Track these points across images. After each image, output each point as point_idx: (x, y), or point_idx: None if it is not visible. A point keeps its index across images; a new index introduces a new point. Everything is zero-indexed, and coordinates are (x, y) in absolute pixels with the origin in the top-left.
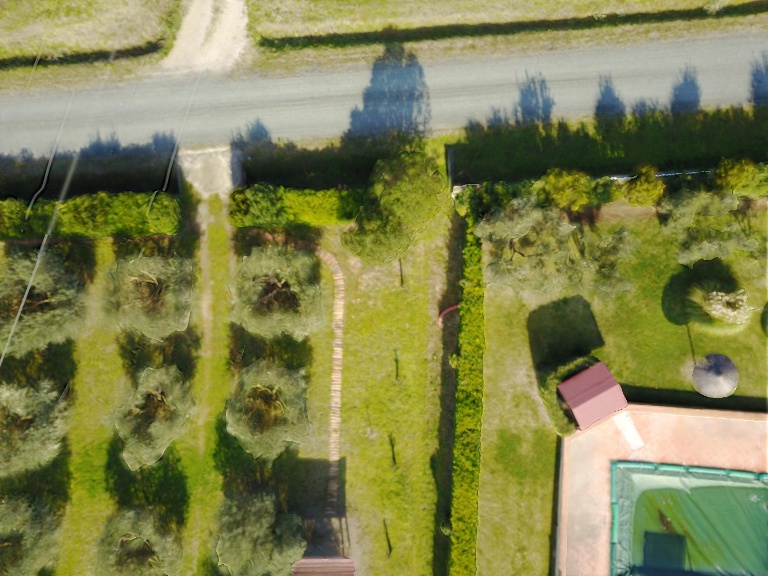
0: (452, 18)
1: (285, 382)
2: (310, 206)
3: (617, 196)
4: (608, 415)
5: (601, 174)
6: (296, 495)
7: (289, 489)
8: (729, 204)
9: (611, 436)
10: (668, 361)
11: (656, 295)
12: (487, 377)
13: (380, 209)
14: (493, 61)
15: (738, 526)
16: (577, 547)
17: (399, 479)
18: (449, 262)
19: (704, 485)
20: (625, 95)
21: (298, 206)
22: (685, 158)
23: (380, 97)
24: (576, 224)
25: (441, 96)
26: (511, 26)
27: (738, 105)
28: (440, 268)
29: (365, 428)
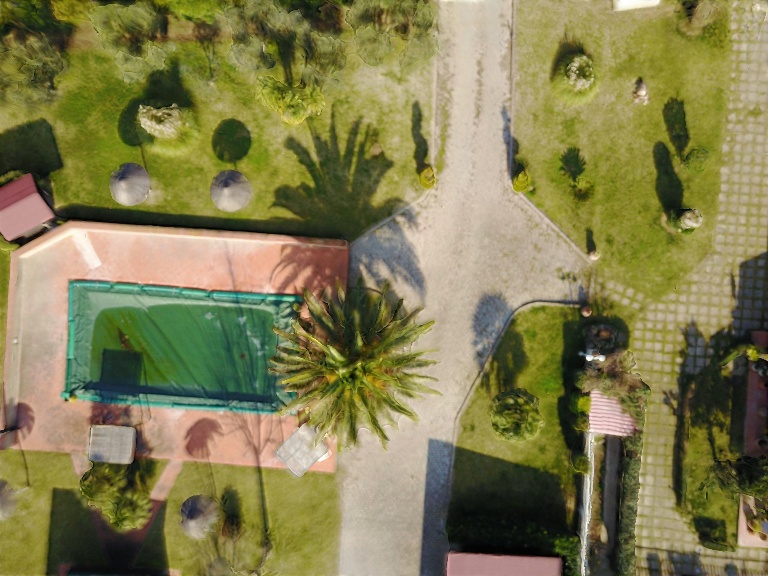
0: None
1: None
2: None
3: None
4: (54, 232)
5: None
6: None
7: None
8: (135, 12)
9: (70, 256)
10: None
11: (114, 117)
12: None
13: None
14: None
15: (193, 342)
16: (34, 363)
17: None
18: None
19: (159, 303)
20: None
21: None
22: None
23: None
24: None
25: None
26: None
27: None
28: None
29: None
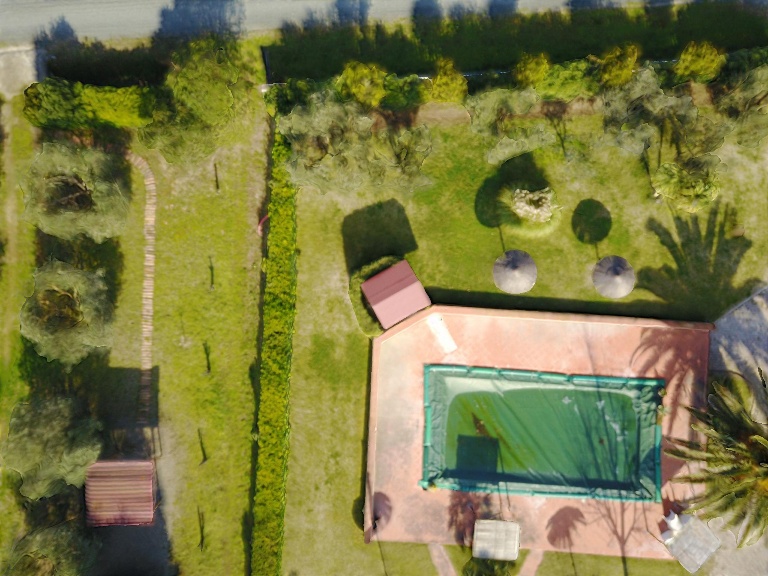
0: None
1: (76, 281)
2: (111, 104)
3: (427, 96)
4: (418, 317)
5: None
6: (106, 405)
7: (99, 399)
8: (527, 97)
9: (424, 340)
10: (480, 264)
11: (470, 198)
12: (302, 283)
13: (174, 102)
14: None
15: (550, 427)
16: (389, 451)
17: (214, 388)
18: (268, 168)
19: (516, 387)
20: None
21: (98, 103)
22: (503, 62)
23: None
24: (393, 128)
25: None
26: None
27: (556, 8)
28: (260, 175)
29: (179, 337)
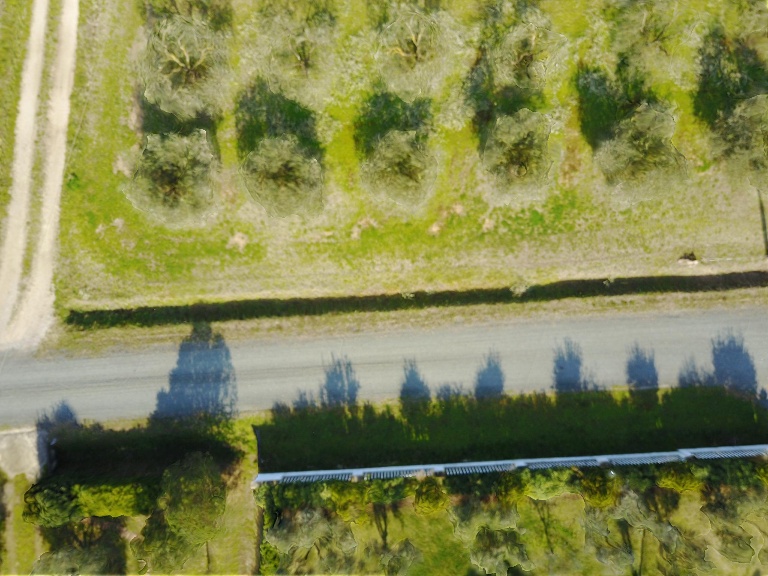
0: (262, 294)
1: None
2: (106, 503)
3: (411, 494)
4: None
5: (405, 457)
6: None
7: None
8: (507, 525)
9: None
10: None
11: None
12: None
13: (164, 524)
14: (299, 343)
15: None
16: None
17: None
18: (257, 539)
19: None
20: (430, 379)
21: (93, 504)
22: (488, 442)
23: (186, 378)
24: (379, 509)
25: (247, 378)
26: (322, 301)
27: (540, 390)
28: (250, 543)
29: None
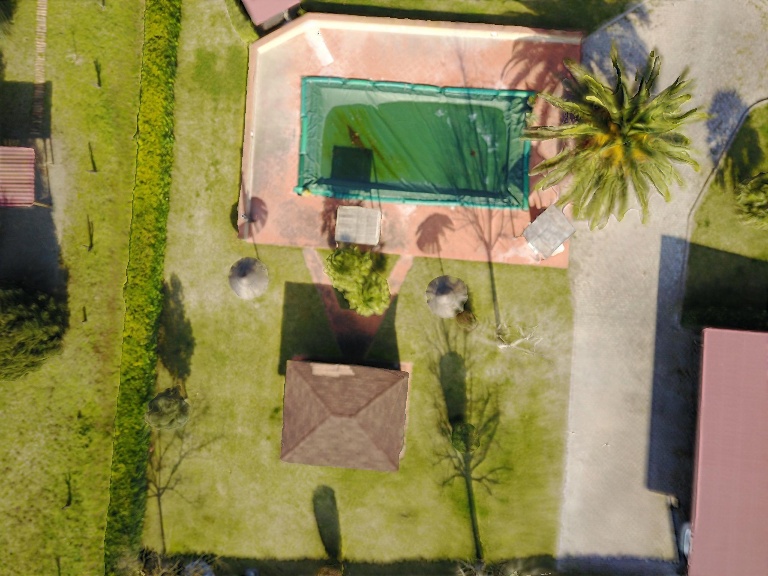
0: None
1: None
2: None
3: None
4: (292, 24)
5: None
6: (2, 117)
7: None
8: None
9: (302, 53)
10: None
11: None
12: (187, 1)
13: None
14: None
15: (423, 140)
16: (267, 159)
17: (104, 104)
18: None
19: (390, 99)
20: None
21: None
22: None
23: None
24: None
25: None
26: None
27: None
28: None
29: (71, 54)
